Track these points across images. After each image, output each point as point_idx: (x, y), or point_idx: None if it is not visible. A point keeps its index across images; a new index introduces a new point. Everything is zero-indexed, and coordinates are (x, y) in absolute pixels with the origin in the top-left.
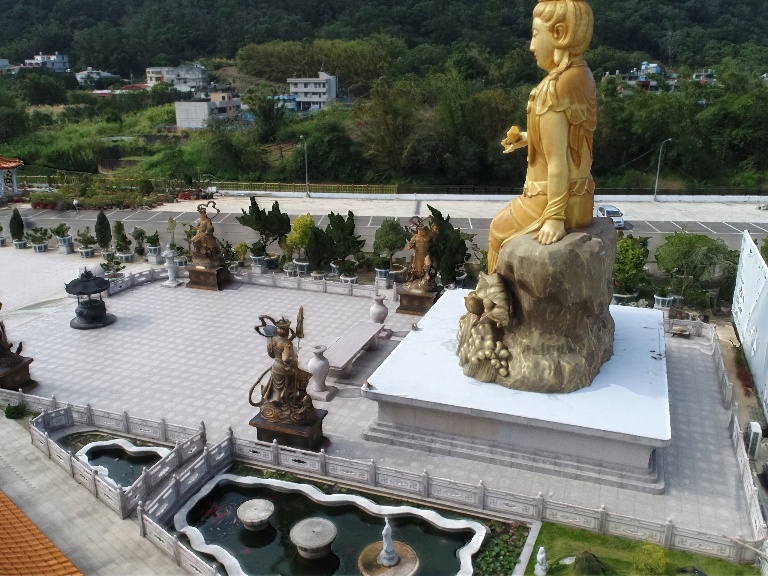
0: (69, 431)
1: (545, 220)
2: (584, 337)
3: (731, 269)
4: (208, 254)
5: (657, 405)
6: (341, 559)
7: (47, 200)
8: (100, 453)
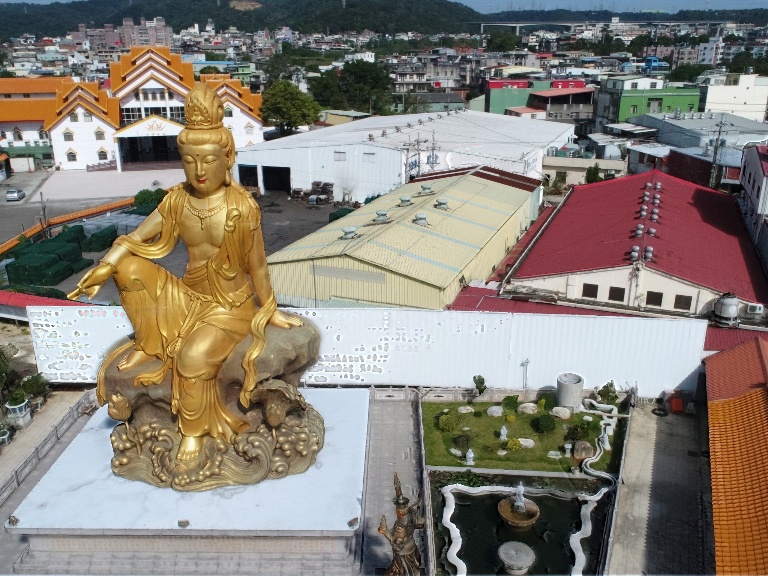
0: None
1: (274, 313)
2: None
3: (14, 350)
4: None
5: (322, 392)
6: (500, 566)
7: None
8: None
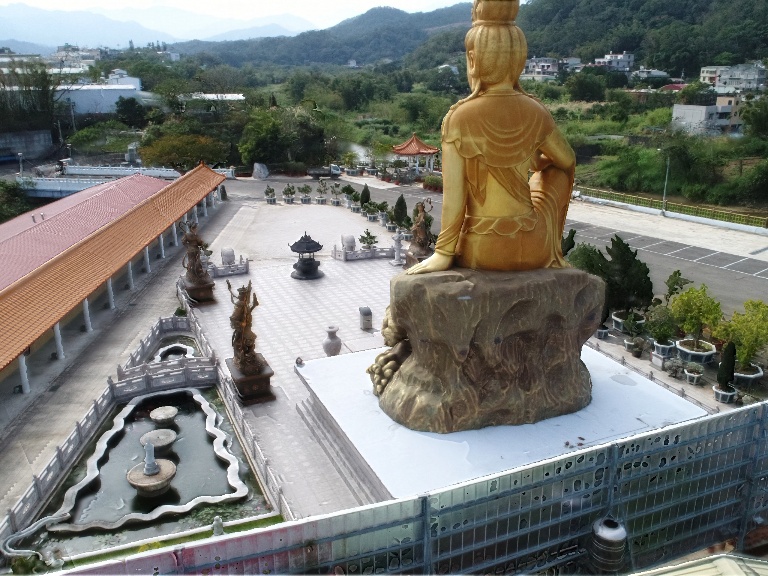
0: (184, 333)
1: None
2: (450, 382)
3: None
4: (421, 243)
5: (459, 474)
6: None
7: (432, 183)
8: (181, 352)
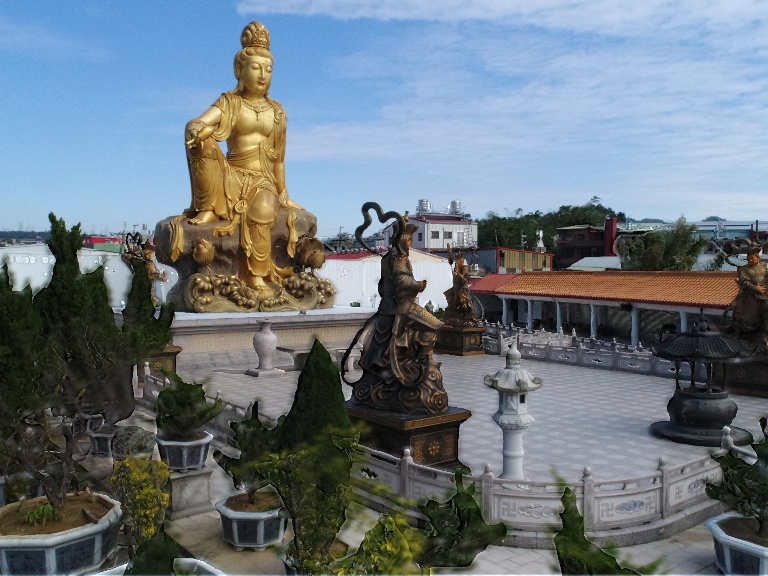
0: None
1: None
2: None
3: None
4: None
5: None
6: None
7: None
8: None
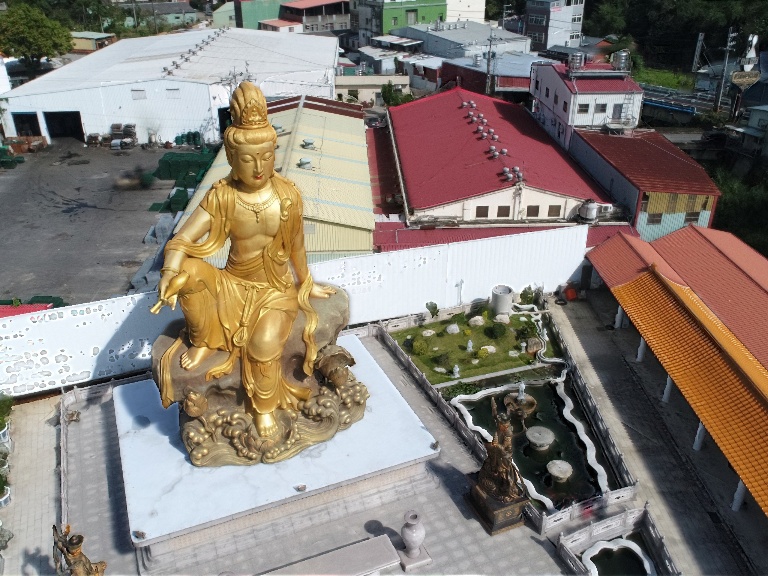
0: None
1: None
2: None
3: None
4: None
5: None
6: None
7: None
8: None
